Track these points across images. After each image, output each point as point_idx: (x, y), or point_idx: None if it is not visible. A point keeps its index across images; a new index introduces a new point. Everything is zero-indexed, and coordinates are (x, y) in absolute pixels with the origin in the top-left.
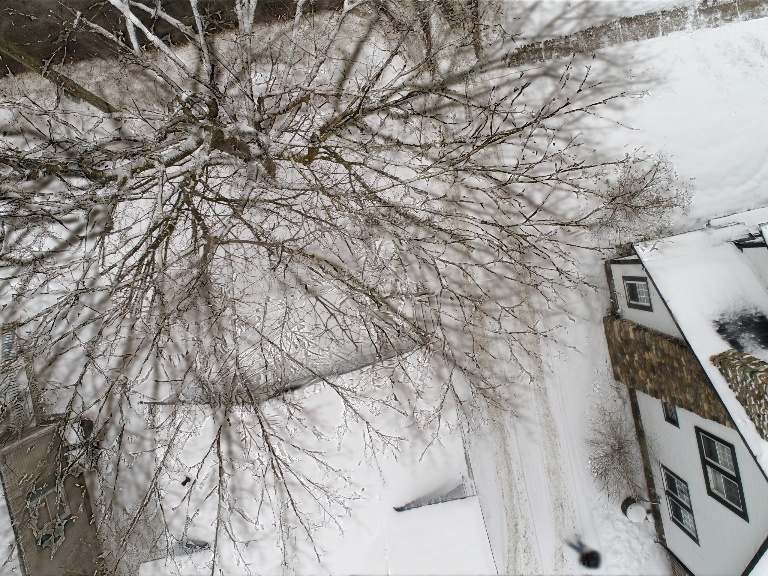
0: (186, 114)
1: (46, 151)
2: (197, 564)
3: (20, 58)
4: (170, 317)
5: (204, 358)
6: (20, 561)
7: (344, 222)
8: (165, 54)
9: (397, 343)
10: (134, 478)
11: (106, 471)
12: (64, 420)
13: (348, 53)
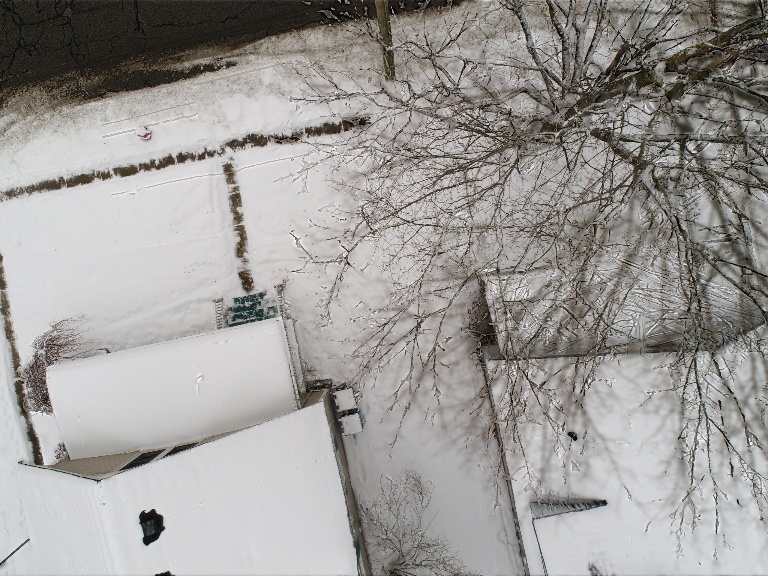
0: (622, 52)
1: (312, 112)
2: (602, 520)
3: (384, 3)
4: (503, 274)
5: (474, 324)
6: (349, 522)
7: (733, 172)
8: (436, 14)
9: (765, 300)
10: (395, 447)
11: (535, 420)
12: (330, 386)
13: (637, 13)
